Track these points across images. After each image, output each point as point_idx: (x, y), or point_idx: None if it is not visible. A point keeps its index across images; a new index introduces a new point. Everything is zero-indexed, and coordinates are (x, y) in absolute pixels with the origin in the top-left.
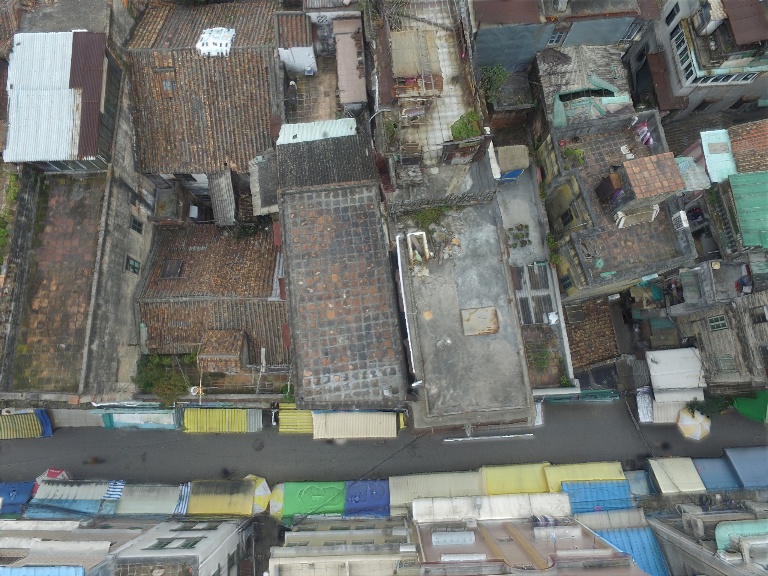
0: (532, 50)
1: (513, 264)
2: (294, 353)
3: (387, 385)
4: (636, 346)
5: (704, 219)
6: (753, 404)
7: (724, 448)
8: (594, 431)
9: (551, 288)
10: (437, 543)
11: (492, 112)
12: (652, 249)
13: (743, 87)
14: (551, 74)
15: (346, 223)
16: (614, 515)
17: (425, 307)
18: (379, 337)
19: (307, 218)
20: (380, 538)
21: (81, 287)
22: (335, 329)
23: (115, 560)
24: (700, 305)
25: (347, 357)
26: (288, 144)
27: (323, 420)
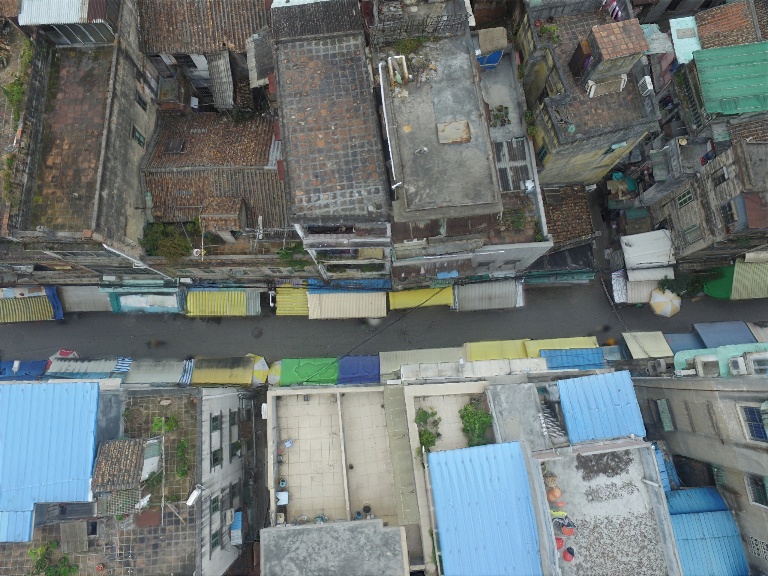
0: None
1: (493, 141)
2: (287, 175)
3: (371, 202)
4: (613, 240)
5: (674, 106)
6: (721, 286)
7: (693, 323)
8: (573, 318)
9: (528, 159)
10: None
11: (474, 1)
12: (620, 116)
13: None
14: None
15: (334, 67)
16: None
17: (404, 122)
18: (364, 162)
19: (299, 63)
20: None
21: (91, 146)
22: (324, 156)
23: (126, 392)
24: (668, 181)
25: (335, 179)
26: (281, 7)
27: (317, 301)
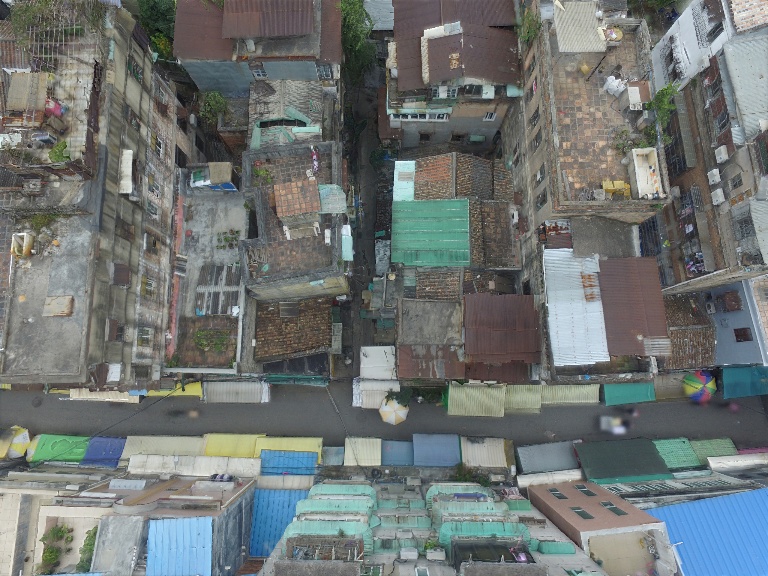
0: (244, 81)
1: (220, 263)
2: None
3: None
4: None
5: None
6: None
7: (413, 433)
8: (325, 412)
9: None
10: (112, 487)
11: (217, 131)
12: (312, 259)
13: (444, 124)
14: (257, 103)
15: (4, 221)
16: (289, 479)
17: (21, 292)
18: None
19: None
20: (78, 481)
21: None
22: None
23: None
24: None
25: None
26: None
27: None
